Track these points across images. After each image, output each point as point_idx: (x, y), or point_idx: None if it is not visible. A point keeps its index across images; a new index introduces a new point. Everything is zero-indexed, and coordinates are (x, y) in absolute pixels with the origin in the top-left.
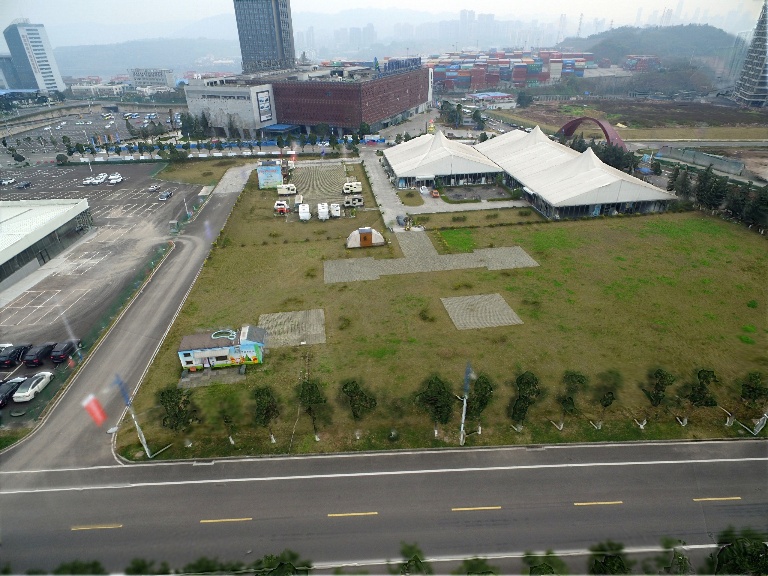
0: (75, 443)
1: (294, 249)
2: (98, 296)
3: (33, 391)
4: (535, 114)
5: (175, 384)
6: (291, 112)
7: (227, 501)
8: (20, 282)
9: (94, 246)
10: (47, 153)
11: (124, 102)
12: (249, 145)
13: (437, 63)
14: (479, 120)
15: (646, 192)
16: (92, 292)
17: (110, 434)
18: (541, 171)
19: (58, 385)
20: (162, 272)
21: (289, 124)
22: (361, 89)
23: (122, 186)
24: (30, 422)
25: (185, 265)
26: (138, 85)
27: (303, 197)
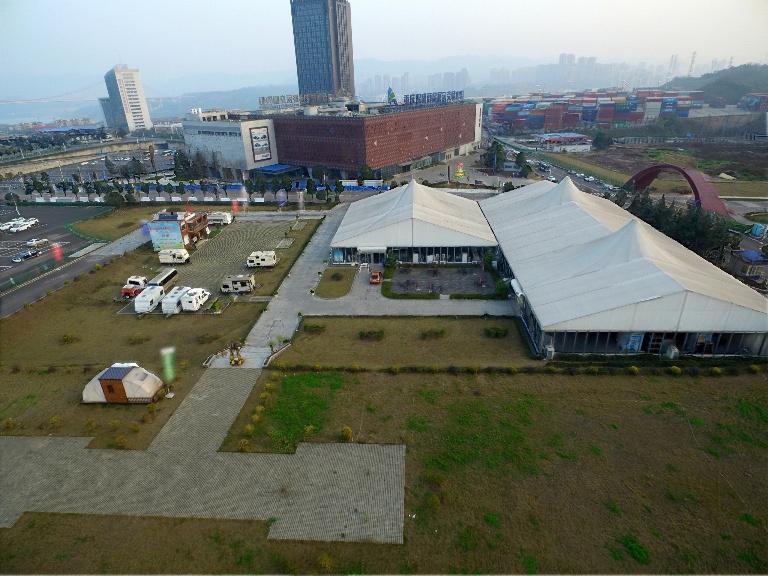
0: None
1: (4, 391)
2: None
3: None
4: (608, 159)
5: None
6: (292, 151)
7: None
8: None
9: None
10: None
11: (176, 139)
12: (214, 189)
13: (512, 102)
14: (523, 165)
15: (742, 316)
16: None
17: None
18: (549, 253)
19: None
20: None
21: (290, 165)
22: (365, 125)
23: (16, 236)
24: None
25: None
26: None
27: (189, 269)
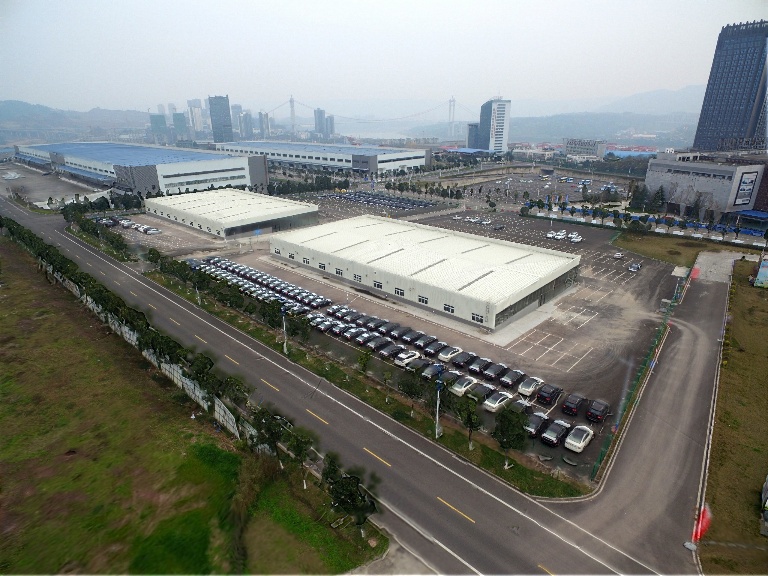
0: (648, 537)
1: None
2: (604, 359)
3: (583, 445)
4: None
5: (756, 524)
6: None
7: None
8: (525, 317)
9: (579, 302)
10: (507, 203)
11: (560, 167)
12: (723, 229)
13: None
14: None
15: None
16: (596, 352)
17: (689, 550)
18: None
19: (600, 448)
20: (668, 356)
21: None
22: None
23: (583, 246)
24: (585, 479)
25: (694, 357)
26: (568, 153)
27: None
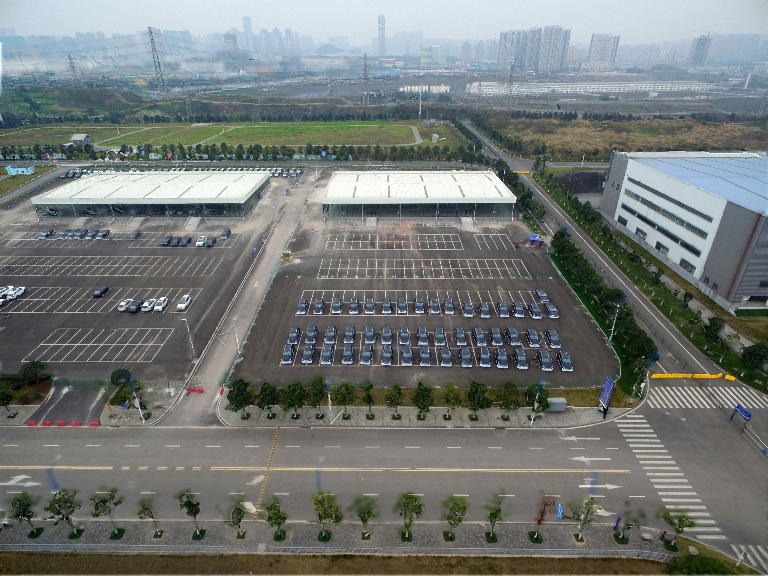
0: None
1: None
2: None
3: None
4: None
5: None
6: None
7: (41, 163)
8: None
9: None
10: None
11: None
12: None
13: None
14: None
15: None
16: None
17: None
18: None
19: None
20: None
21: None
22: None
23: None
24: None
25: None
26: None
27: None
